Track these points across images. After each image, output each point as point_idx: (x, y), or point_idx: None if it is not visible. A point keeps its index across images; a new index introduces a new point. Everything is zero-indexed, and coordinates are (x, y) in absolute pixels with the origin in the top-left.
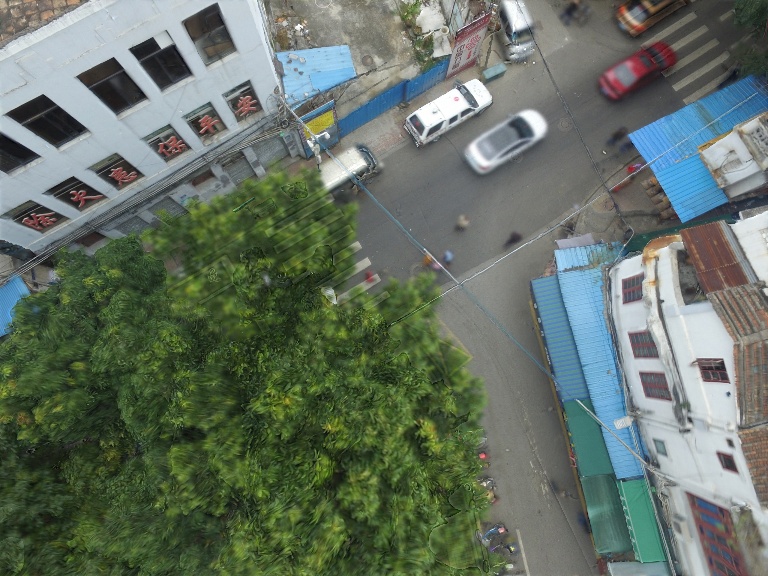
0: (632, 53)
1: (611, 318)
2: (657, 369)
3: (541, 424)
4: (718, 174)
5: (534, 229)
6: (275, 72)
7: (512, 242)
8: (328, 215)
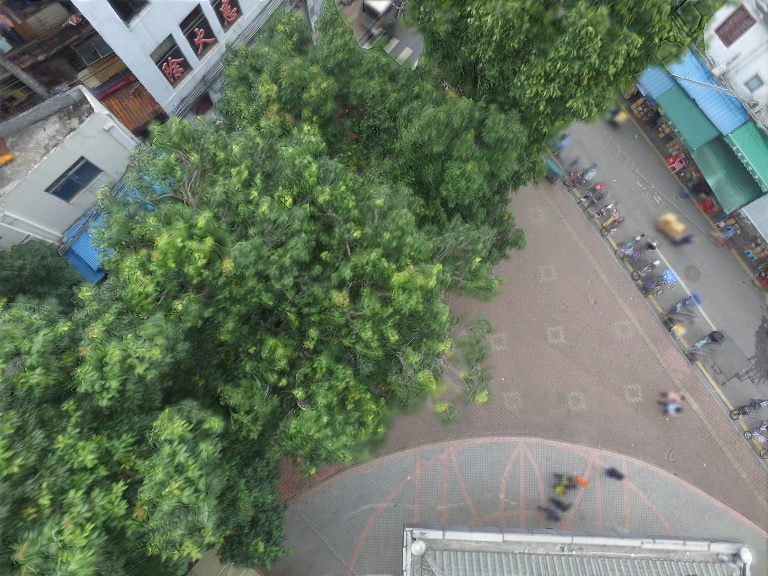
0: None
1: None
2: (734, 7)
3: (634, 151)
4: None
5: None
6: None
7: None
8: (386, 45)
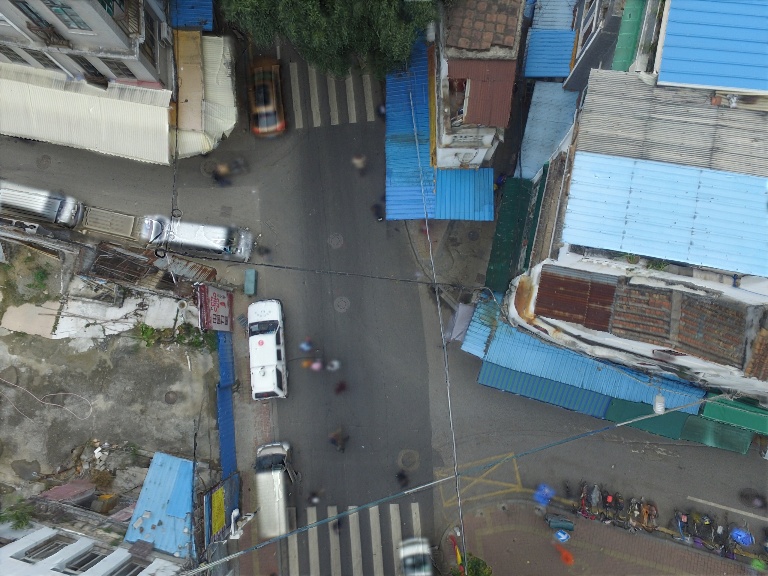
0: (299, 140)
1: (553, 342)
2: None
3: (603, 421)
4: (465, 166)
5: (420, 326)
6: (149, 573)
7: (422, 354)
8: (307, 523)
